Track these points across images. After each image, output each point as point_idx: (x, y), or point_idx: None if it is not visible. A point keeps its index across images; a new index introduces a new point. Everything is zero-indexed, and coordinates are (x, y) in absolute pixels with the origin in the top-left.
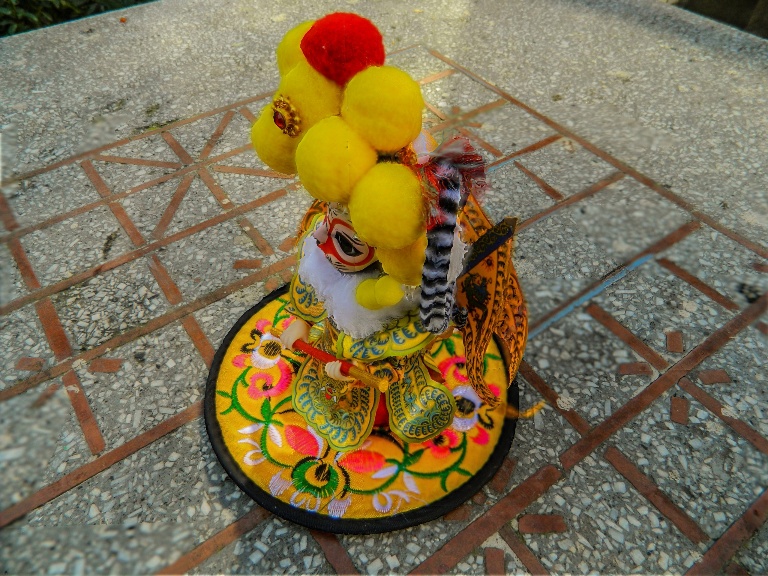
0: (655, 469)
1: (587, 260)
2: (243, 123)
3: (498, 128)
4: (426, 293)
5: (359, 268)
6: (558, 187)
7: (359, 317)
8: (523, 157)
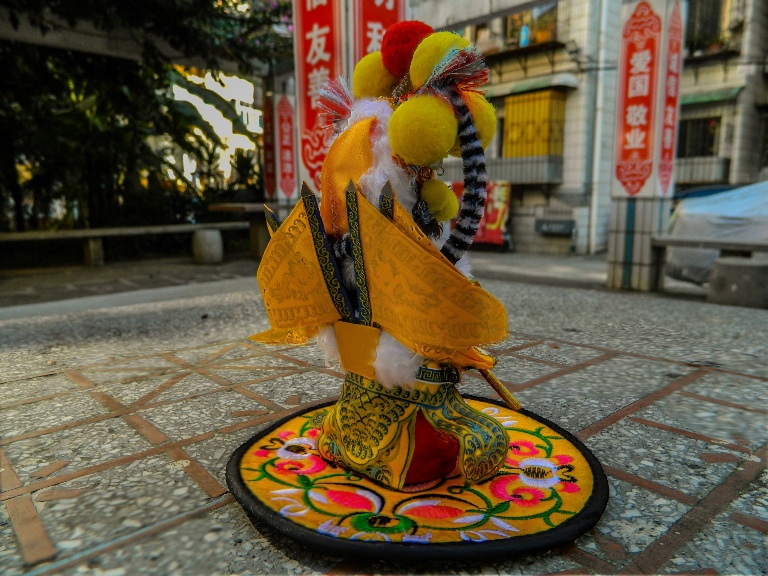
0: (128, 437)
1: None
2: None
3: None
4: None
5: None
6: None
7: None
8: None
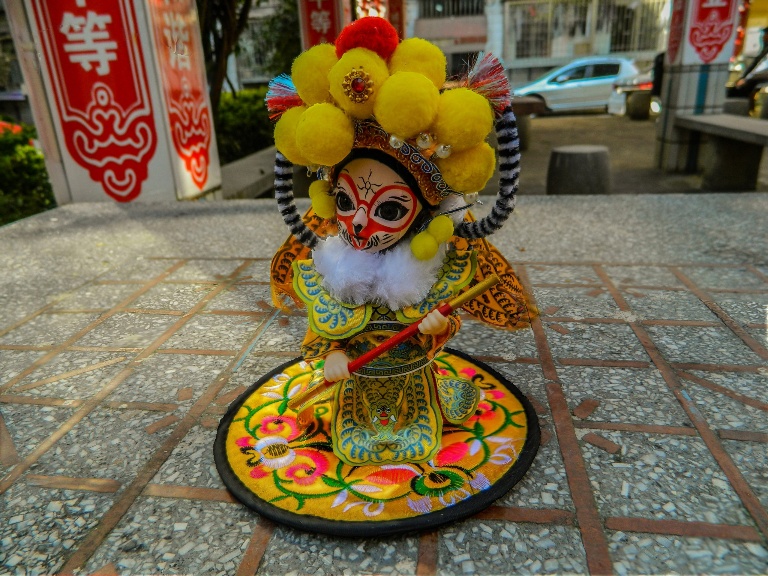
0: (589, 354)
1: None
2: (6, 353)
3: (266, 274)
4: (512, 163)
5: (402, 233)
6: None
7: (418, 276)
8: None
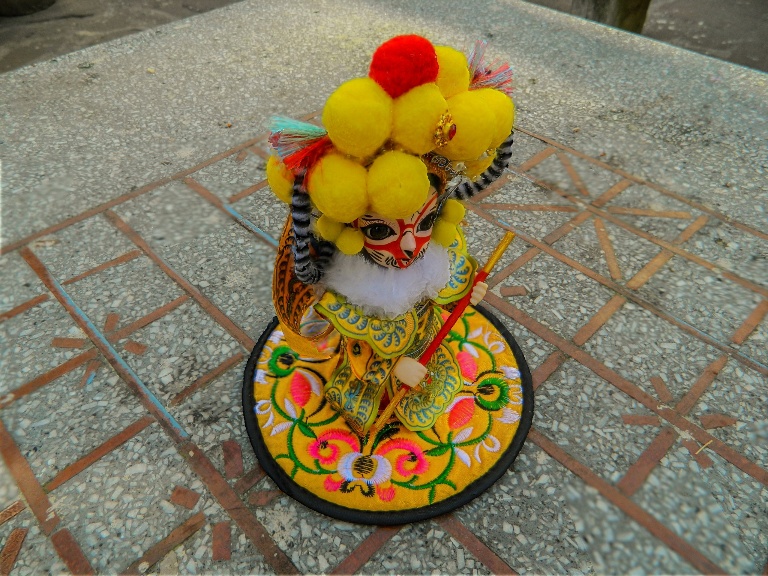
0: None
1: (229, 239)
2: None
3: None
4: None
5: None
6: (119, 253)
7: None
8: (56, 277)
